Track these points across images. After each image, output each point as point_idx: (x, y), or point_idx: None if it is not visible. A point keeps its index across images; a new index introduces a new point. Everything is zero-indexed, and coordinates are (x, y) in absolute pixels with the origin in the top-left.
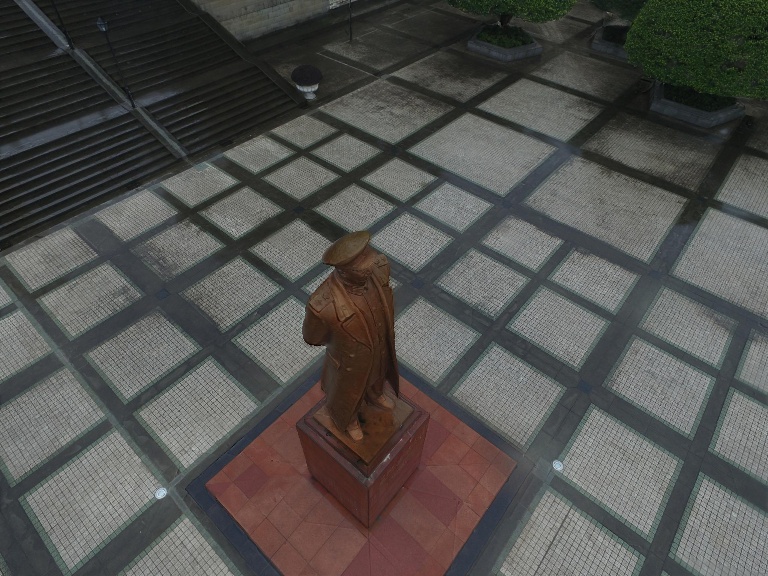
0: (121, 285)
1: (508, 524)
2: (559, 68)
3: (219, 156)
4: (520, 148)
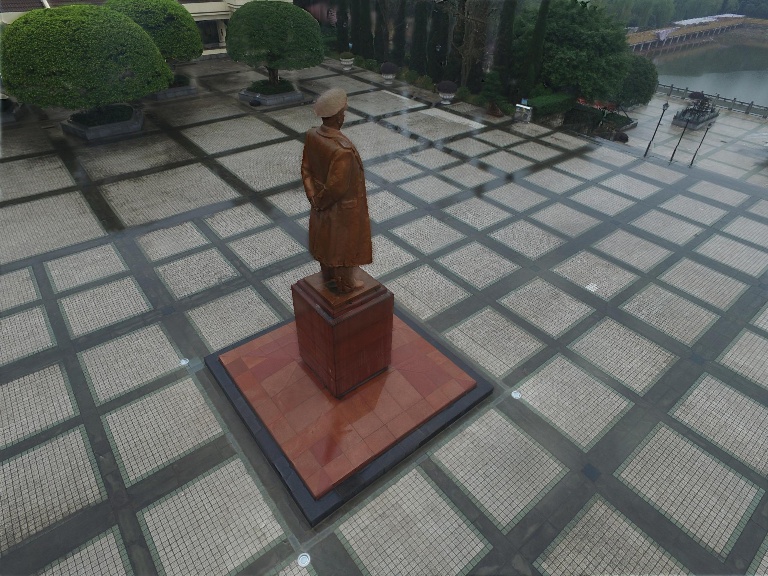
0: None
1: None
2: None
3: None
4: (52, 208)
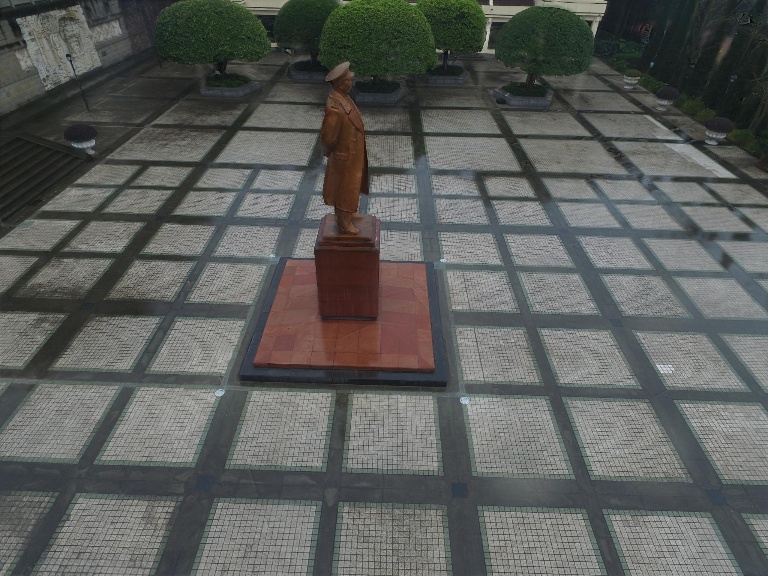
0: (34, 319)
1: (441, 292)
2: (281, 93)
3: (38, 212)
4: (294, 139)
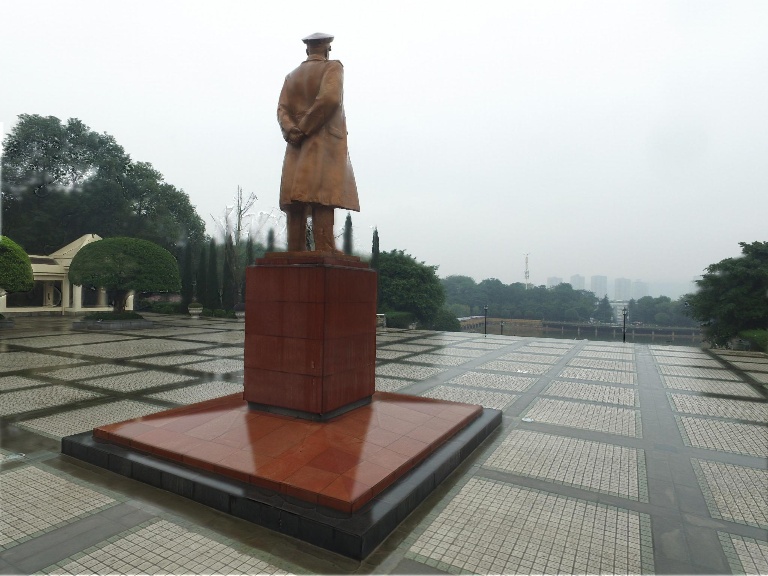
0: None
1: None
2: None
3: None
4: None
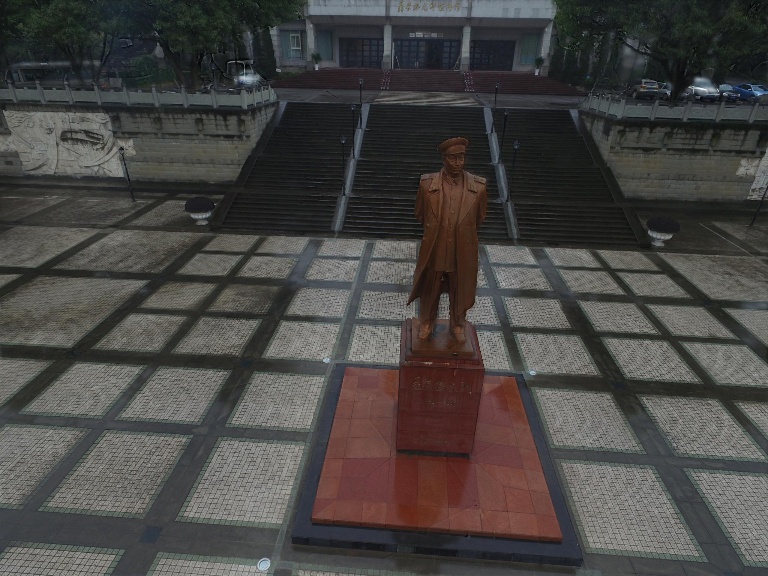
0: (412, 275)
1: (505, 570)
2: None
3: (539, 248)
4: None
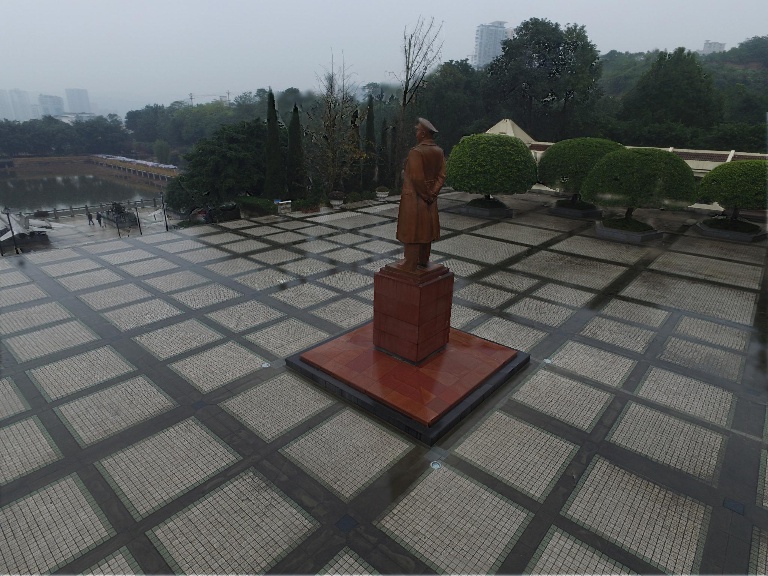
0: None
1: None
2: None
3: None
4: None
